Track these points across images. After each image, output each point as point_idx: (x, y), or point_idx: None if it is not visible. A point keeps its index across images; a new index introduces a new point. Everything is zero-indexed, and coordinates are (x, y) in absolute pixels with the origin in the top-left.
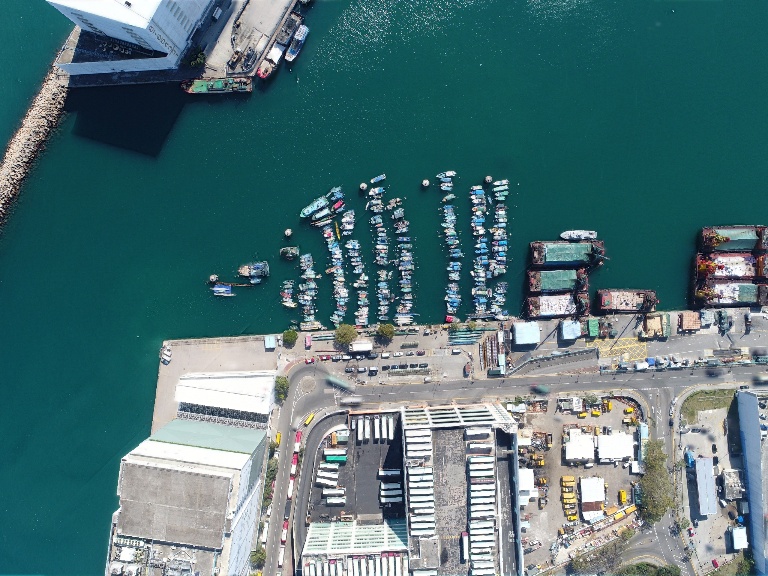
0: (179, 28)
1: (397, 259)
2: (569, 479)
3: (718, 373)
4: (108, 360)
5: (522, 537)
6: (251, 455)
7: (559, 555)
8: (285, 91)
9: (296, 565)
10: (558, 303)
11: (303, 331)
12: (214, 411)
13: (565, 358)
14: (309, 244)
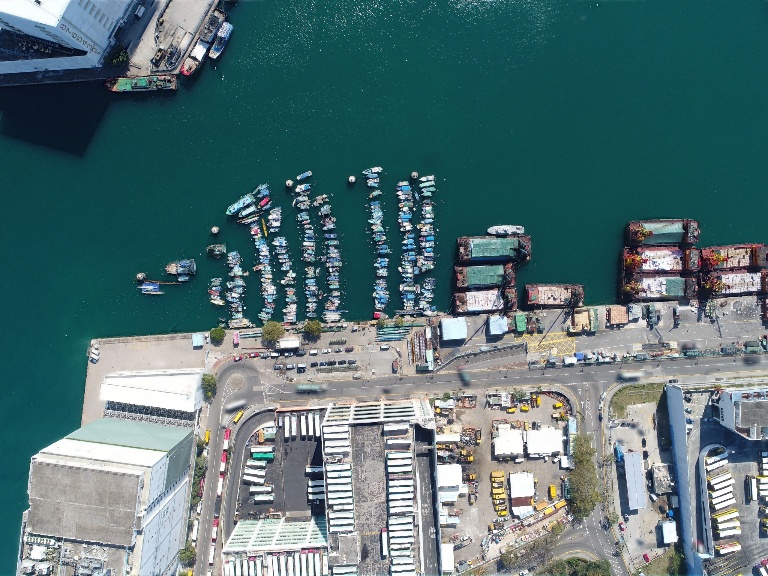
0: (98, 26)
1: (324, 256)
2: (498, 474)
3: (647, 367)
4: (37, 359)
5: (453, 533)
6: (168, 453)
7: (490, 551)
8: (210, 88)
9: None
10: (485, 298)
11: (231, 329)
12: (141, 409)
13: (494, 353)
14: (236, 241)
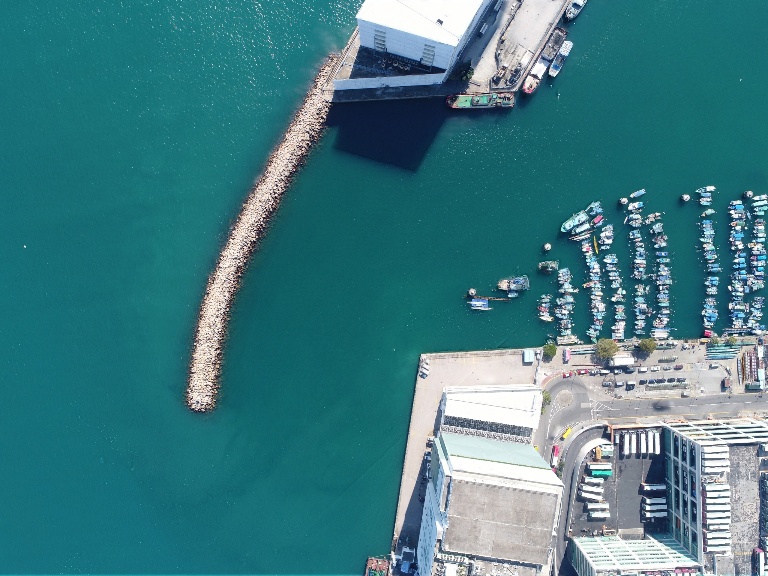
0: (461, 44)
1: (655, 273)
2: None
3: None
4: (364, 373)
5: None
6: None
7: None
8: (546, 106)
9: None
10: None
11: (560, 345)
12: (477, 425)
13: None
14: (567, 258)
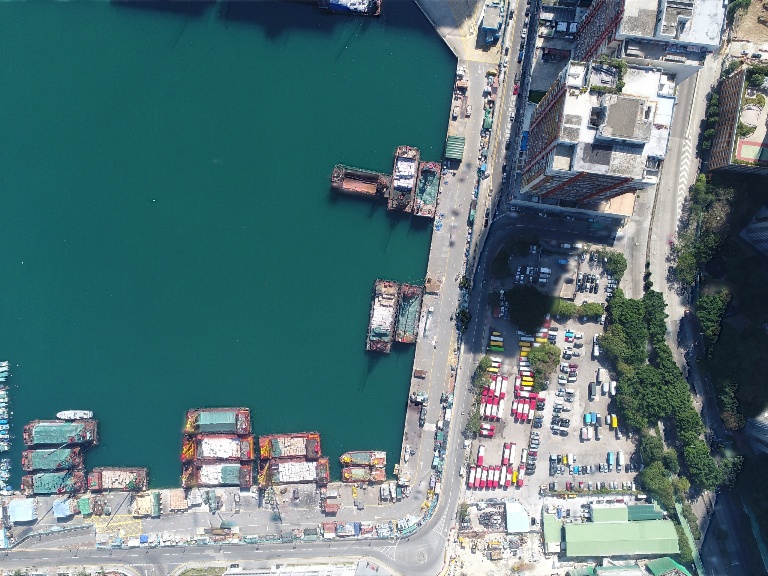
0: None
1: None
2: None
3: (209, 551)
4: None
5: None
6: None
7: None
8: None
9: None
10: (52, 481)
11: None
12: None
13: (64, 533)
14: None
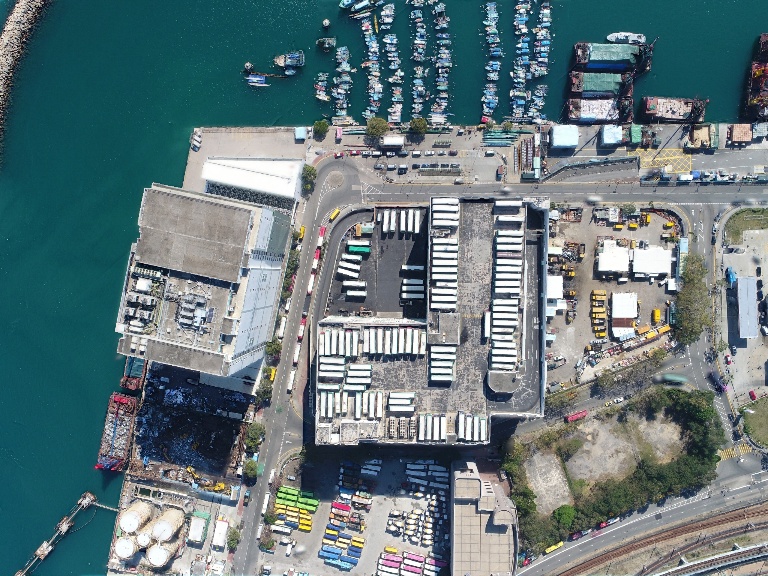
0: None
1: (435, 56)
2: (600, 292)
3: (767, 191)
4: (139, 145)
5: (546, 352)
6: (274, 211)
7: (584, 374)
8: None
9: (311, 359)
10: (600, 107)
11: (334, 125)
12: (240, 195)
13: (604, 167)
14: (346, 37)
